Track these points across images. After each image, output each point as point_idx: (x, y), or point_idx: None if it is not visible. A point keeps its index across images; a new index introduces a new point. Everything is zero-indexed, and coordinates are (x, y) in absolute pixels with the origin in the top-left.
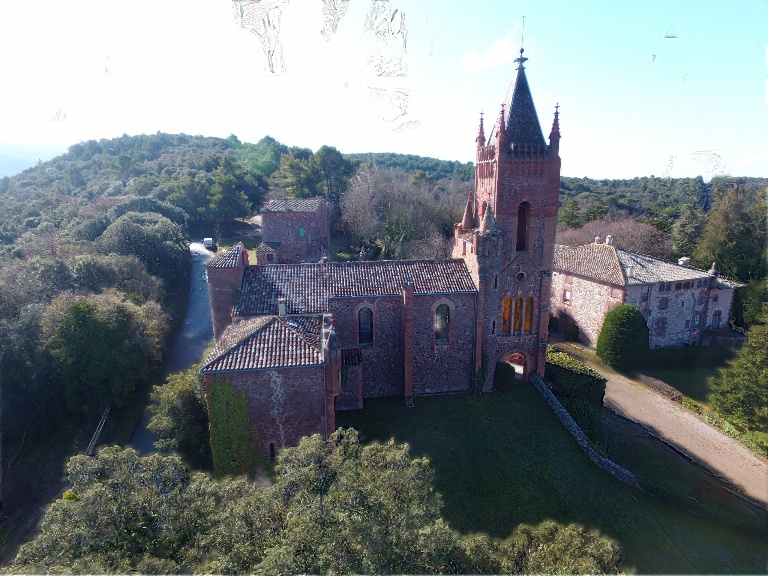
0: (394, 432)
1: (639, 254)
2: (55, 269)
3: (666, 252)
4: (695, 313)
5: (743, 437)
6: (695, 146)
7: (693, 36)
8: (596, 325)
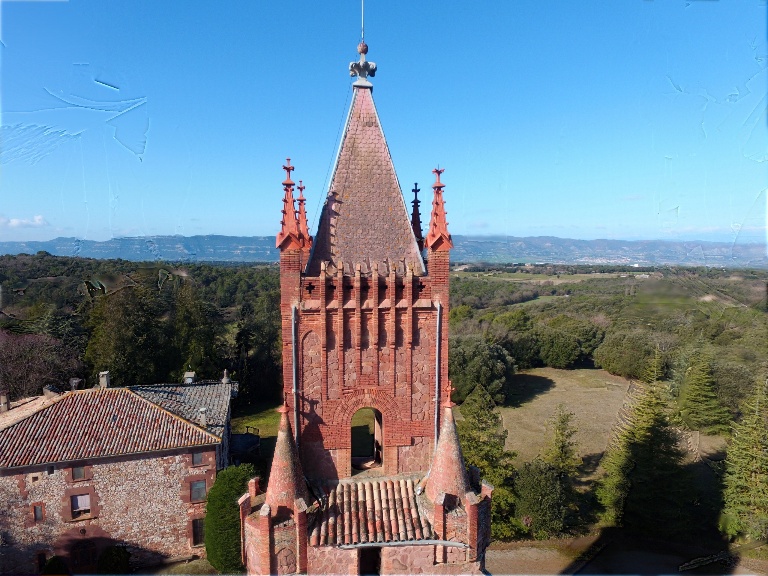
0: None
1: (153, 387)
2: None
3: (75, 367)
4: (227, 435)
5: None
6: (121, 230)
7: (139, 95)
8: (168, 524)
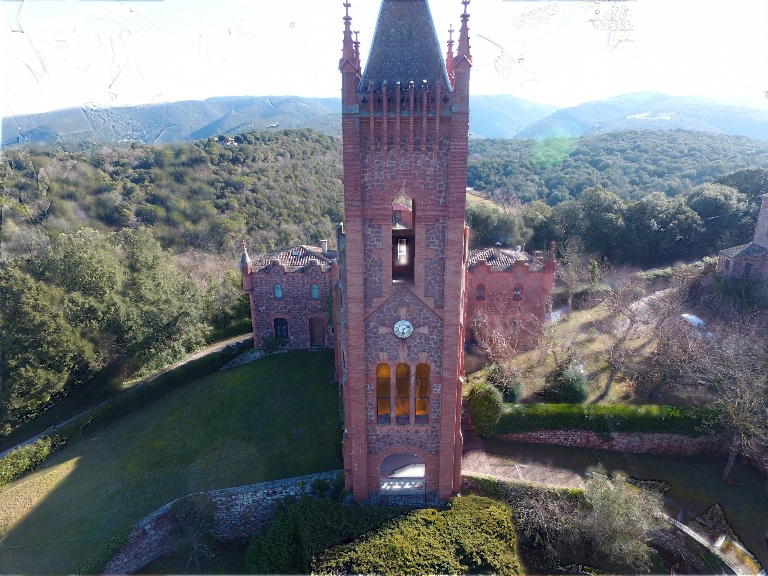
0: (297, 373)
1: None
2: (469, 212)
3: None
4: None
5: None
6: None
7: None
8: None
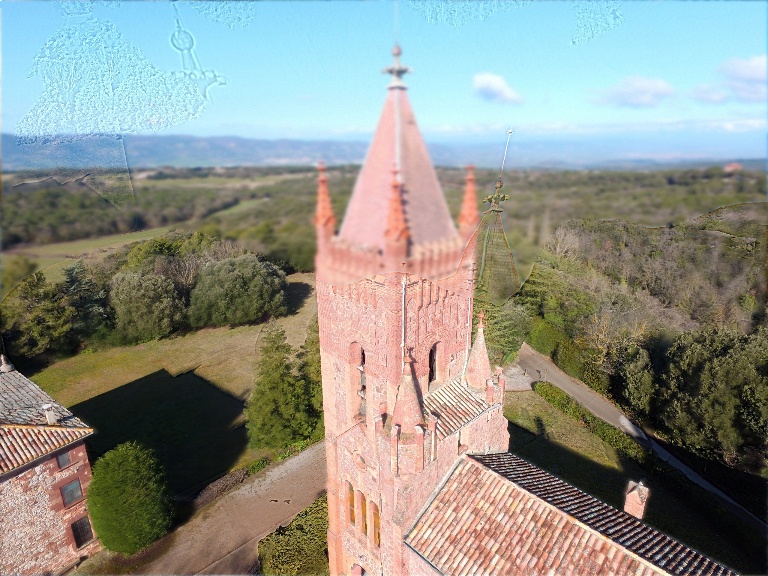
0: None
1: None
2: None
3: None
4: None
5: (313, 439)
6: None
7: None
8: (41, 542)
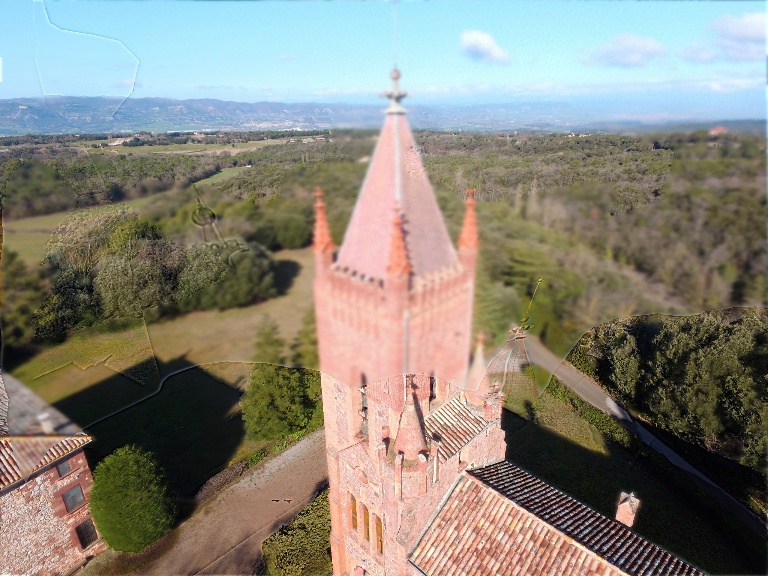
0: None
1: None
2: None
3: None
4: None
5: (309, 428)
6: None
7: None
8: (47, 547)
